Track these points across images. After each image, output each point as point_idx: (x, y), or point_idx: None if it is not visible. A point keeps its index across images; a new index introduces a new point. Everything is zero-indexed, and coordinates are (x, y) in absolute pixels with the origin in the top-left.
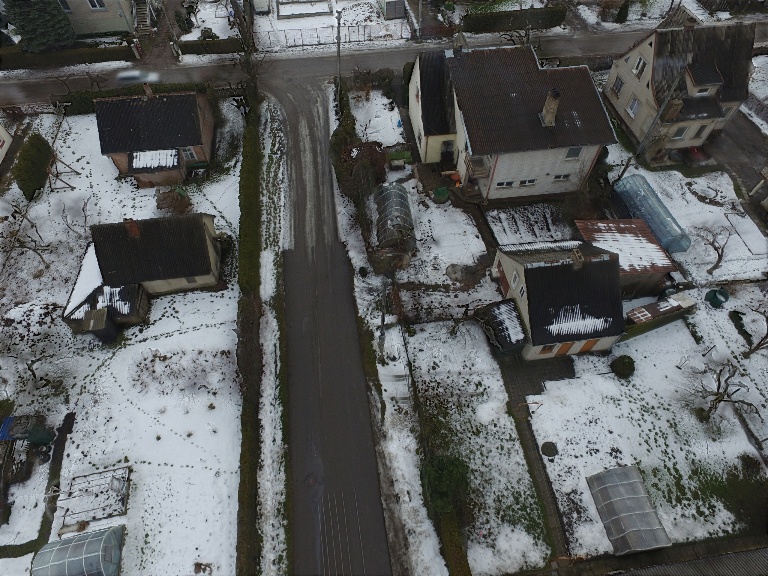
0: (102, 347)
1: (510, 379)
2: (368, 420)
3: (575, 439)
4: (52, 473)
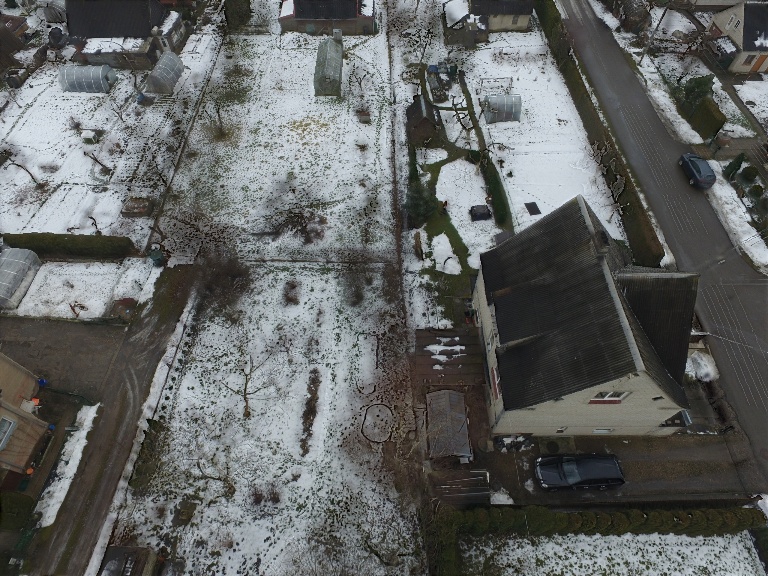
0: (466, 49)
1: (722, 78)
2: (638, 84)
3: (766, 101)
4: (463, 88)
